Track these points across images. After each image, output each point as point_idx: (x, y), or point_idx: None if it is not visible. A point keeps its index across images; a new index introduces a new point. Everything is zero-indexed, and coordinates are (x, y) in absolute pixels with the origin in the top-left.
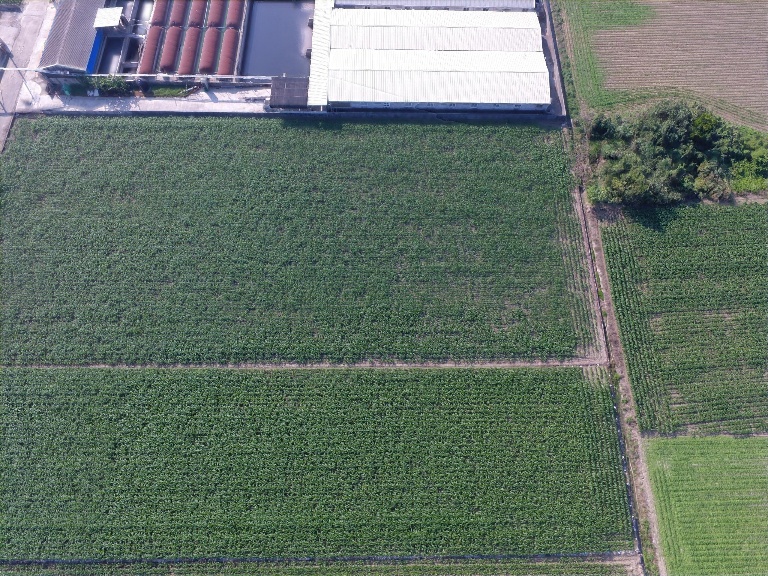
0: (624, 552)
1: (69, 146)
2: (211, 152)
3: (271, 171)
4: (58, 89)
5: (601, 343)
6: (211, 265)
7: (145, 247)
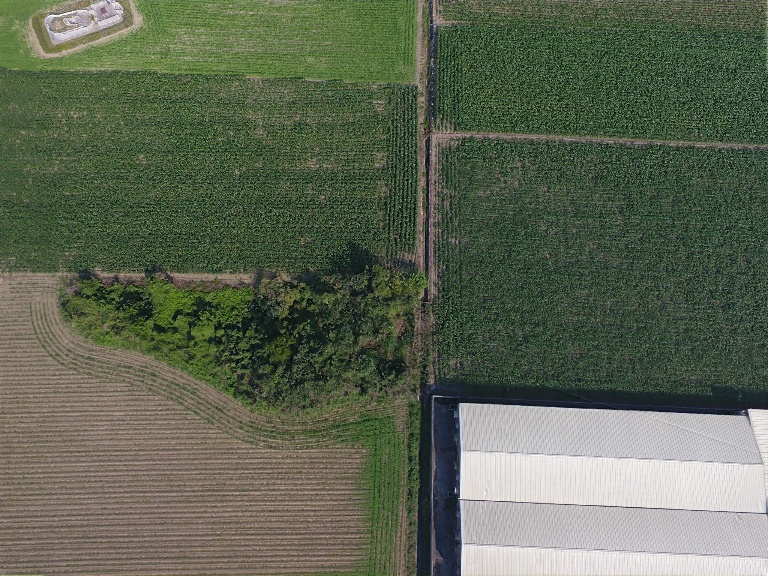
0: None
1: None
2: None
3: None
4: None
5: (435, 149)
6: None
7: None
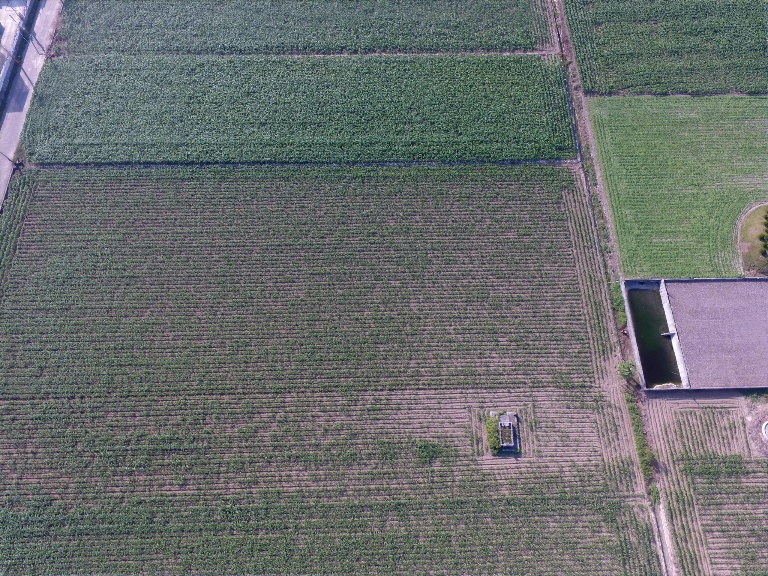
0: (569, 161)
1: None
2: None
3: None
4: None
5: (555, 41)
6: None
7: None
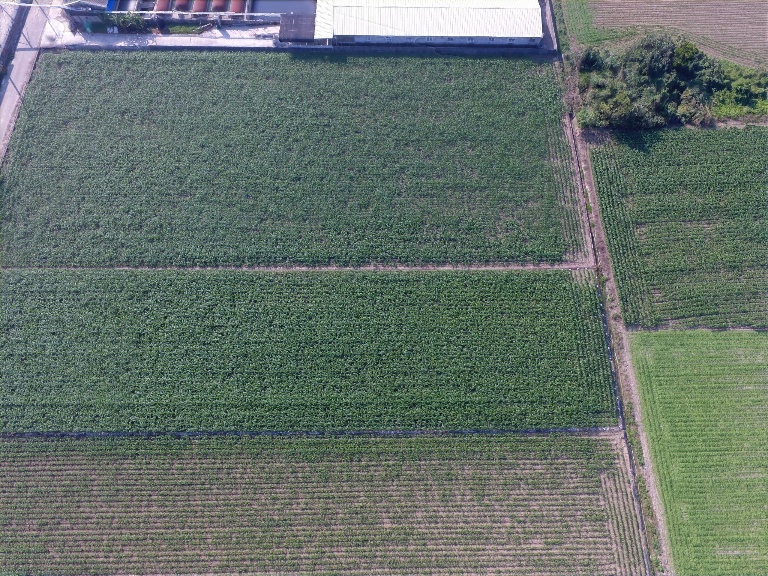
0: (609, 428)
1: (91, 77)
2: (224, 82)
3: (280, 99)
4: (80, 27)
5: (589, 249)
6: (226, 181)
7: (164, 165)
